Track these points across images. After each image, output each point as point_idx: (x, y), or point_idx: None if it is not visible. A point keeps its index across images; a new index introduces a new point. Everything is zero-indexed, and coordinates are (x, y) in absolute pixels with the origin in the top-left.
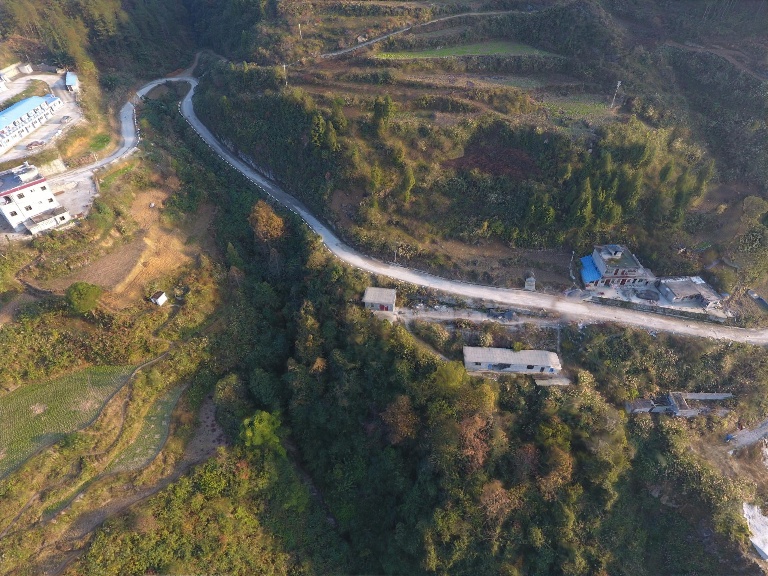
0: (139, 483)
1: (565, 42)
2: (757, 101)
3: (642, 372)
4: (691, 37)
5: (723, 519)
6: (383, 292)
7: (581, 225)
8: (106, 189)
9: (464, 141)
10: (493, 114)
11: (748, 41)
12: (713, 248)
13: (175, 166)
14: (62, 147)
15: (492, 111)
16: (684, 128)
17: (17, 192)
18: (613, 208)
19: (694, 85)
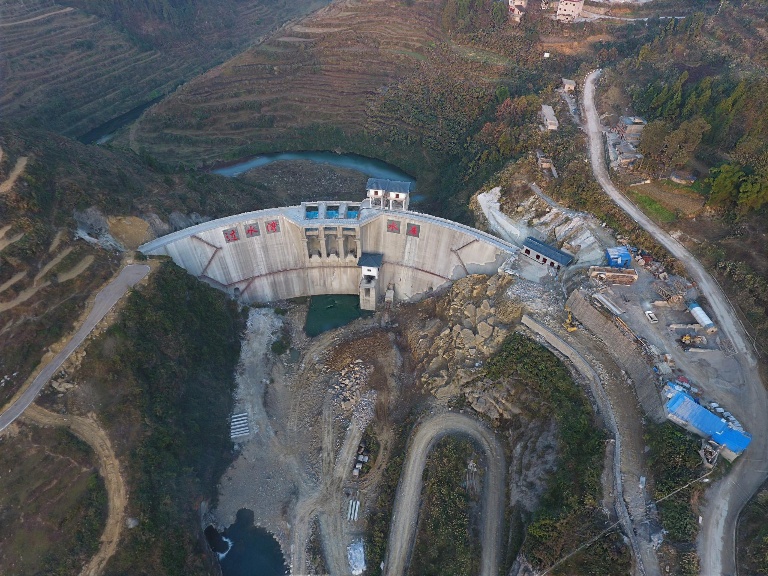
0: (478, 82)
1: None
2: None
3: None
4: None
5: None
6: (572, 83)
7: None
8: (596, 23)
9: (707, 61)
10: None
11: None
12: (684, 165)
13: (628, 30)
14: (614, 6)
15: None
16: None
17: (567, 1)
18: None
19: None
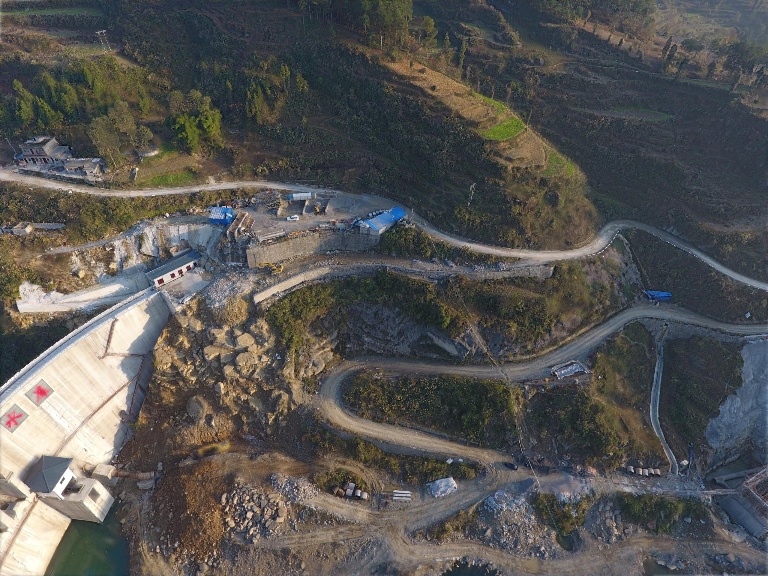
0: None
1: (106, 6)
2: (219, 49)
3: (4, 208)
4: (201, 5)
5: (0, 288)
6: None
7: (22, 122)
8: None
9: None
10: (17, 52)
11: (226, 7)
12: None
13: None
14: None
15: (17, 50)
16: (164, 67)
17: None
18: (46, 111)
19: (199, 39)
